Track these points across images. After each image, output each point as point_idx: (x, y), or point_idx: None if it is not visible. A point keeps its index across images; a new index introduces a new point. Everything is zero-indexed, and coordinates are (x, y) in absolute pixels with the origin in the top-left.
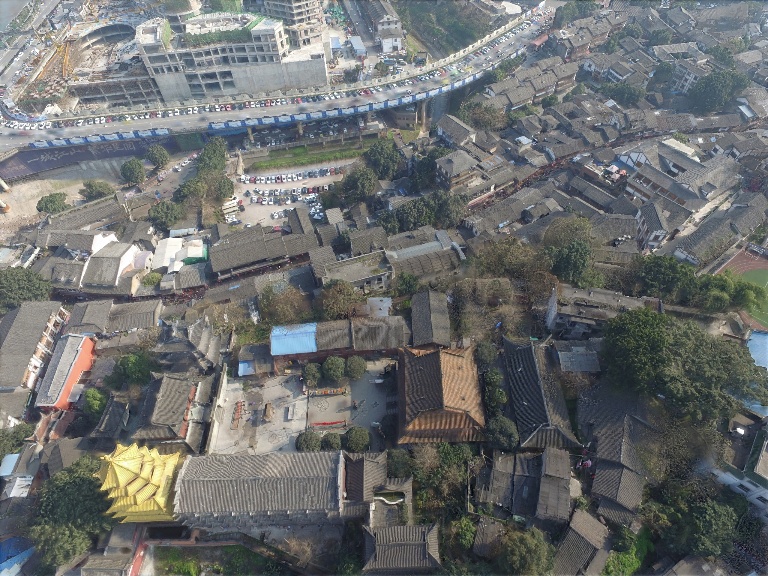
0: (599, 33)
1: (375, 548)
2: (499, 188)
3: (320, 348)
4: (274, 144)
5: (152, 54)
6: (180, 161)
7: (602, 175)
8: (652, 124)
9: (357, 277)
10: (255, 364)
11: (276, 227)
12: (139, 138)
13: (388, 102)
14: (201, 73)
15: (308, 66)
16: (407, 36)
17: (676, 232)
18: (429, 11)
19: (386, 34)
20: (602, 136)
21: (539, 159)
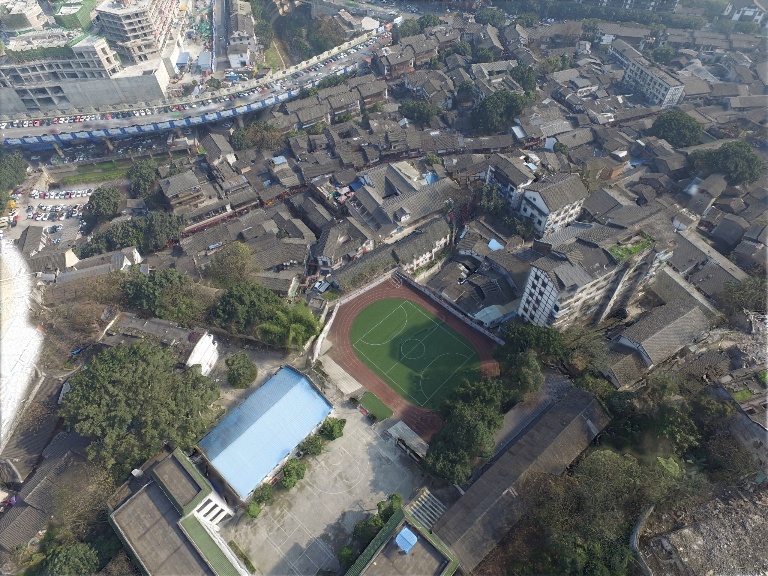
0: (423, 50)
1: None
2: (240, 208)
3: None
4: (81, 159)
5: None
6: None
7: (334, 197)
8: (415, 145)
9: None
10: None
11: (7, 245)
12: None
13: (190, 119)
14: (30, 88)
15: (140, 82)
16: (273, 51)
17: (350, 258)
18: (302, 26)
19: (232, 50)
20: (363, 156)
21: (290, 179)
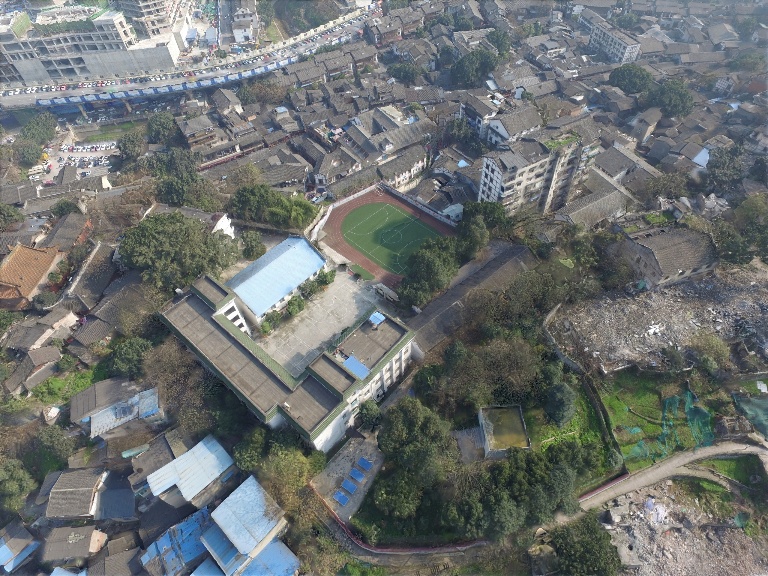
0: (410, 21)
1: None
2: (247, 149)
3: None
4: (104, 120)
5: (6, 42)
6: None
7: (329, 137)
8: (400, 96)
9: None
10: None
11: (47, 181)
12: None
13: (200, 82)
14: (55, 59)
15: (154, 53)
16: (274, 28)
17: (342, 177)
18: (300, 6)
19: (236, 25)
20: (355, 106)
21: (291, 125)
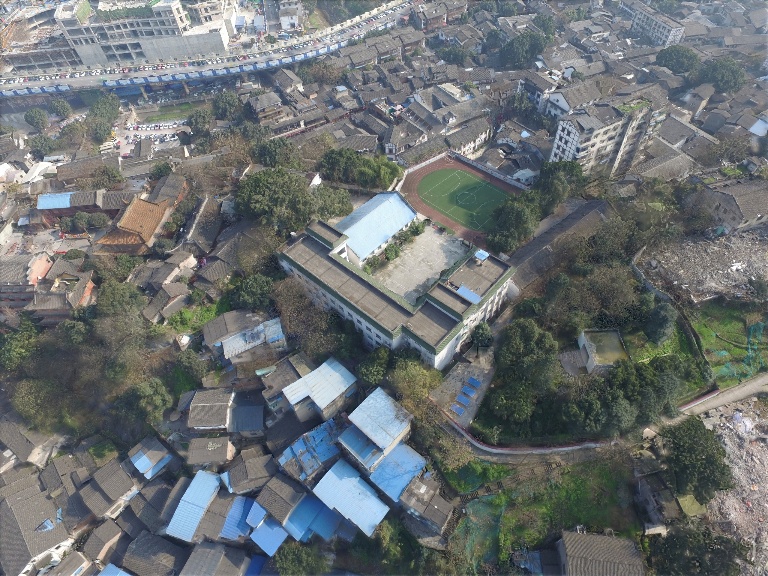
0: (454, 7)
1: (34, 296)
2: (310, 125)
3: (72, 205)
4: (163, 101)
5: (70, 28)
6: (83, 114)
7: (389, 113)
8: (454, 76)
9: (141, 173)
10: (29, 217)
11: (124, 154)
12: (46, 93)
13: (256, 64)
14: (114, 44)
15: (207, 39)
16: (316, 17)
17: (410, 147)
18: None
19: (283, 13)
20: (410, 86)
21: (350, 103)
